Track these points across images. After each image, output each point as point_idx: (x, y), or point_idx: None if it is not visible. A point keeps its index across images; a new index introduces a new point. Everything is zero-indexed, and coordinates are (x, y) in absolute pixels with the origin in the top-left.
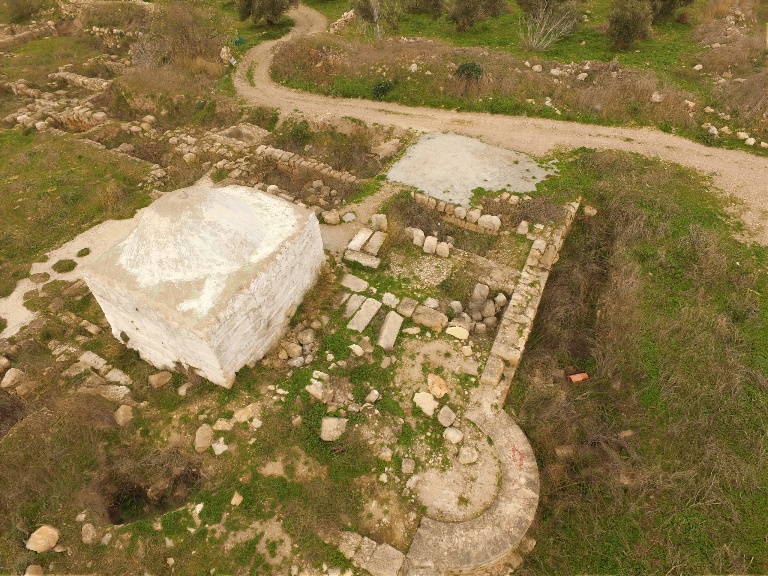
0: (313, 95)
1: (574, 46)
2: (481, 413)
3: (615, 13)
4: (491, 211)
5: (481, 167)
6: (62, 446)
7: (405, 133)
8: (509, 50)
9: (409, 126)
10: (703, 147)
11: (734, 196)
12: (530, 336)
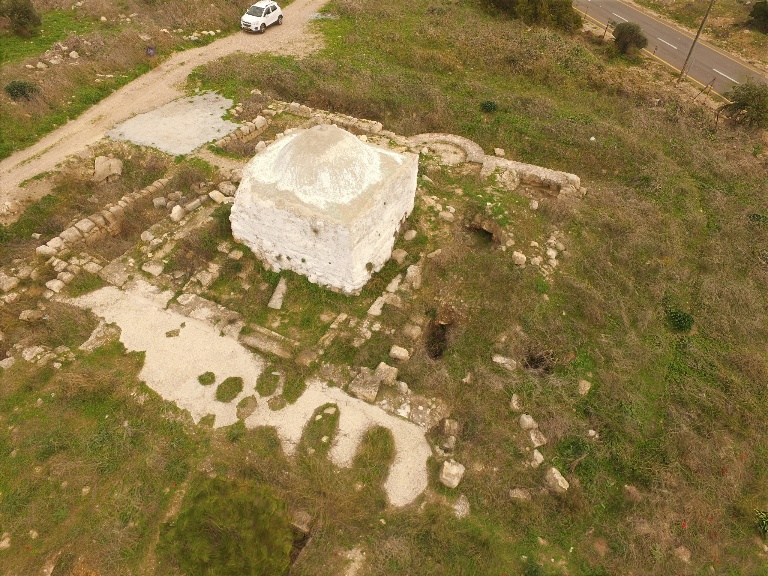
0: None
1: None
2: (411, 143)
3: (7, 3)
4: (252, 117)
5: (190, 115)
6: None
7: (93, 150)
8: None
9: (82, 146)
10: (206, 47)
11: None
12: None
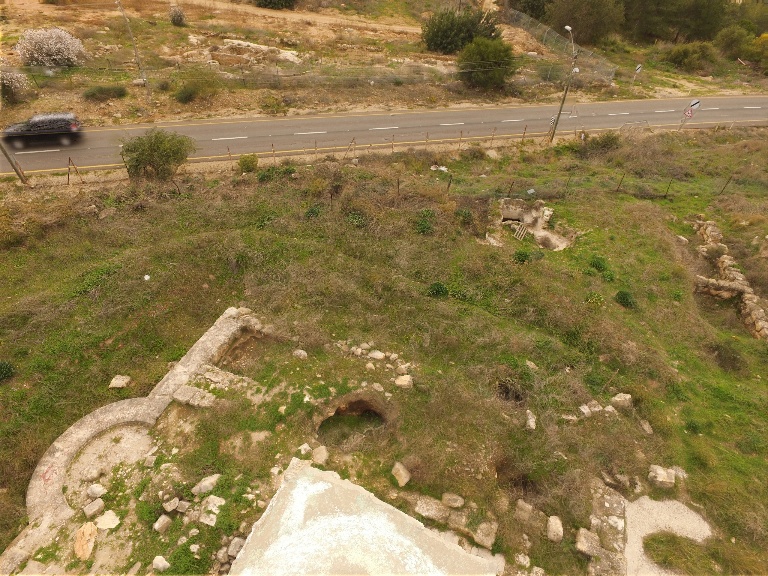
0: None
1: None
2: (55, 517)
3: None
4: None
5: None
6: (430, 435)
7: None
8: None
9: None
10: None
11: None
12: None
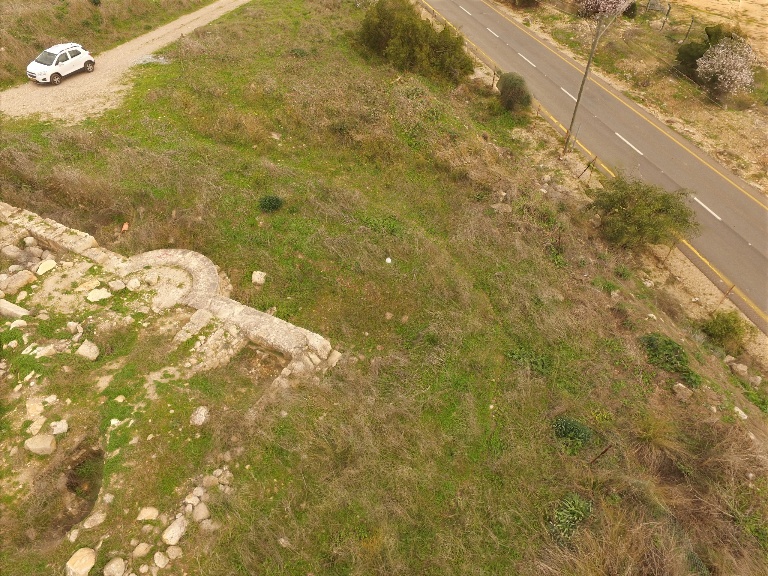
0: None
1: None
2: (125, 268)
3: None
4: None
5: None
6: None
7: None
8: None
9: None
10: None
11: (32, 113)
12: None
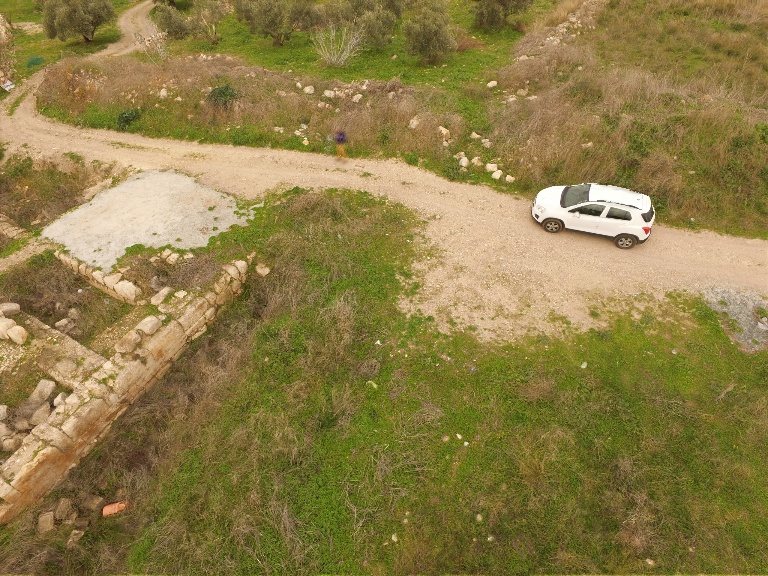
0: (63, 125)
1: (381, 61)
2: None
3: (406, 25)
4: (129, 276)
5: (164, 216)
6: None
7: (122, 172)
8: (310, 67)
9: (131, 163)
10: (445, 182)
11: (436, 247)
12: (98, 446)
